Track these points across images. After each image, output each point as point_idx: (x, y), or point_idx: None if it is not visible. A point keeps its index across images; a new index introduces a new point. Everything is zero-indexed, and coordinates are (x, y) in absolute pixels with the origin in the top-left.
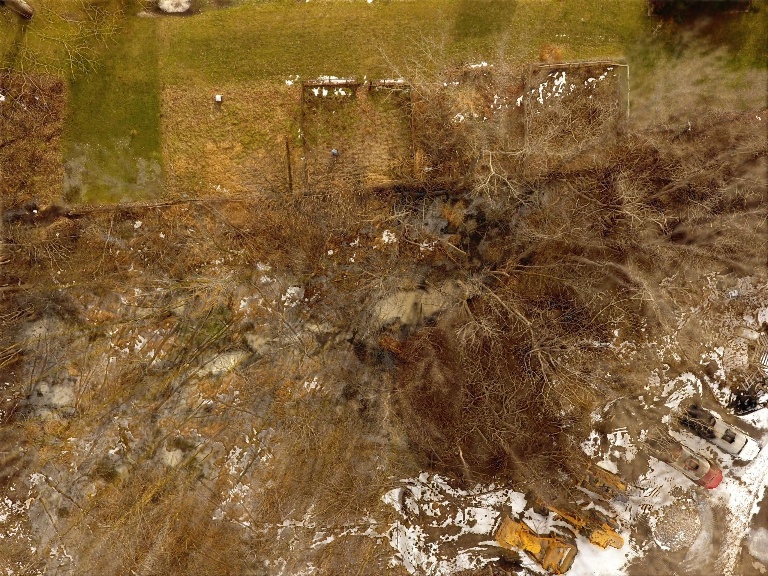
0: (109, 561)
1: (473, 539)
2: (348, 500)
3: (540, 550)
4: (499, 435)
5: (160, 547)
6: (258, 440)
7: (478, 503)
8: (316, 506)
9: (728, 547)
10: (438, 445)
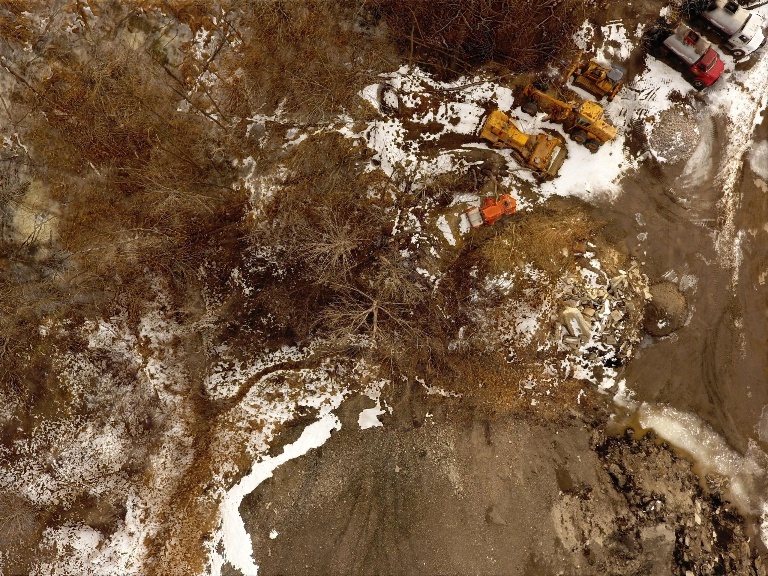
0: (66, 154)
1: (456, 140)
2: (323, 96)
3: (527, 146)
4: (485, 24)
5: (119, 124)
6: (227, 22)
7: (462, 98)
8: (288, 101)
9: (728, 161)
10: (419, 10)
